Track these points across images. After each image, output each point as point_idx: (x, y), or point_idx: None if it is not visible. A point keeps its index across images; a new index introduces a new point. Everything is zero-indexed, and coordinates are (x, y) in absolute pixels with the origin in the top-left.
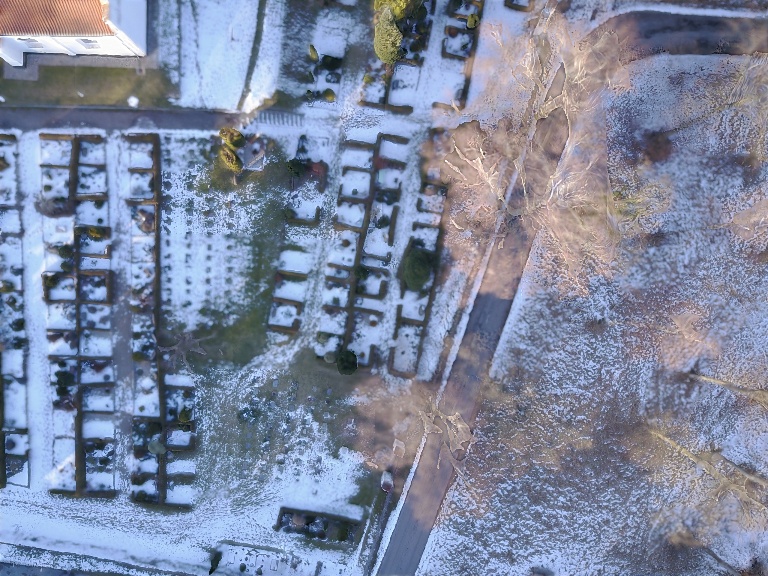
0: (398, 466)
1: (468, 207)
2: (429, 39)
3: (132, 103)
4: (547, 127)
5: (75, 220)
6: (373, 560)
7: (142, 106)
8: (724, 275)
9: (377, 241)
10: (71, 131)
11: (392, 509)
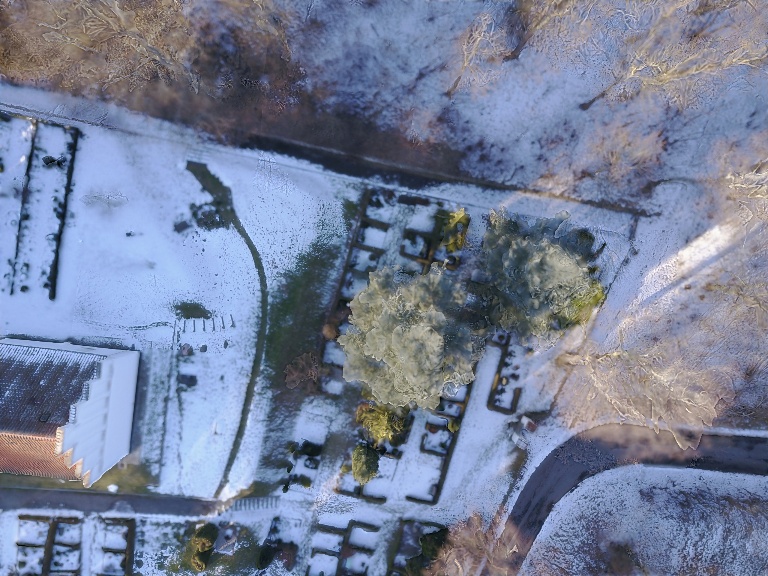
0: None
1: None
2: (409, 435)
3: (112, 489)
4: (516, 527)
5: None
6: None
7: (121, 491)
8: None
9: None
10: (50, 512)
11: None
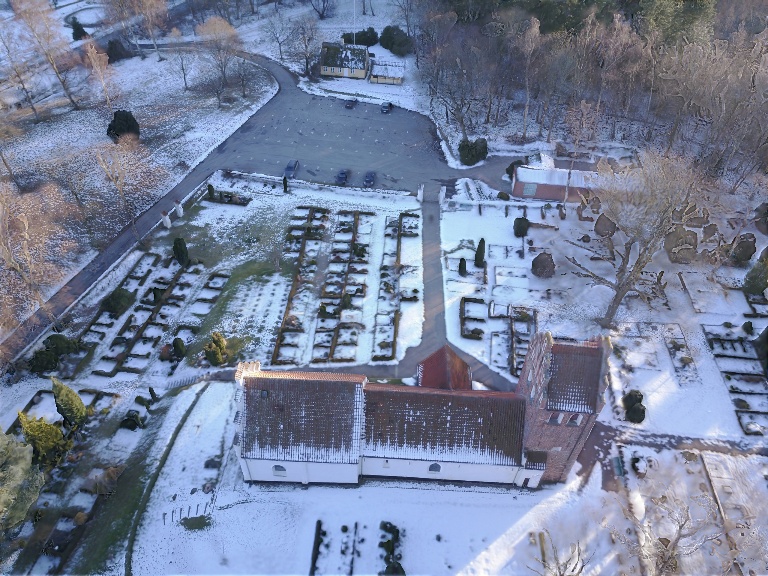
0: None
1: (68, 334)
2: None
3: None
4: None
5: None
6: None
7: None
8: None
9: None
10: (333, 366)
11: None
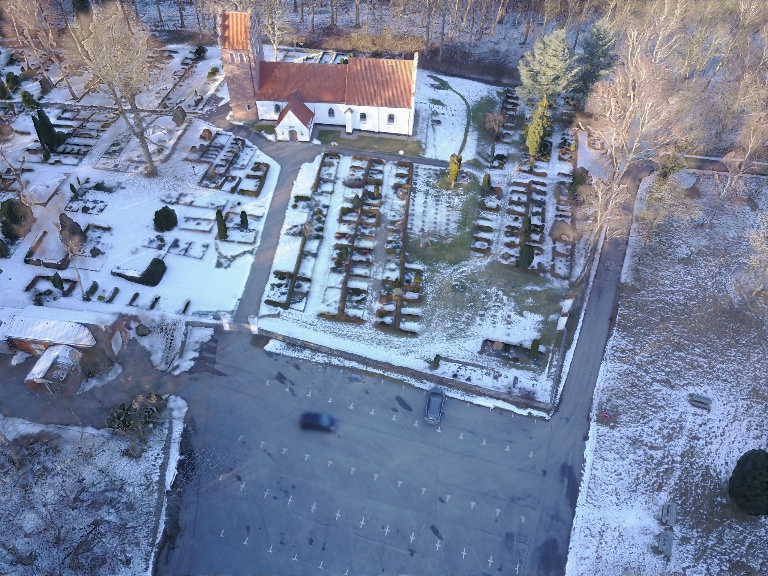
0: (567, 325)
1: (587, 211)
2: (551, 154)
3: (401, 153)
4: None
5: None
6: (558, 380)
7: (405, 155)
8: (759, 246)
9: (534, 220)
10: None
11: (568, 349)
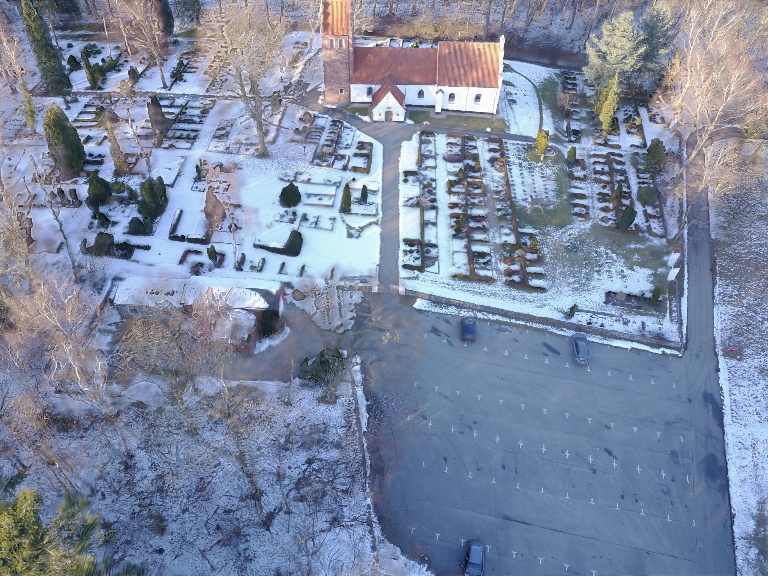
0: None
1: (665, 178)
2: None
3: (488, 130)
4: None
5: (463, 164)
6: (680, 323)
7: (492, 132)
8: None
9: None
10: None
11: (681, 297)
